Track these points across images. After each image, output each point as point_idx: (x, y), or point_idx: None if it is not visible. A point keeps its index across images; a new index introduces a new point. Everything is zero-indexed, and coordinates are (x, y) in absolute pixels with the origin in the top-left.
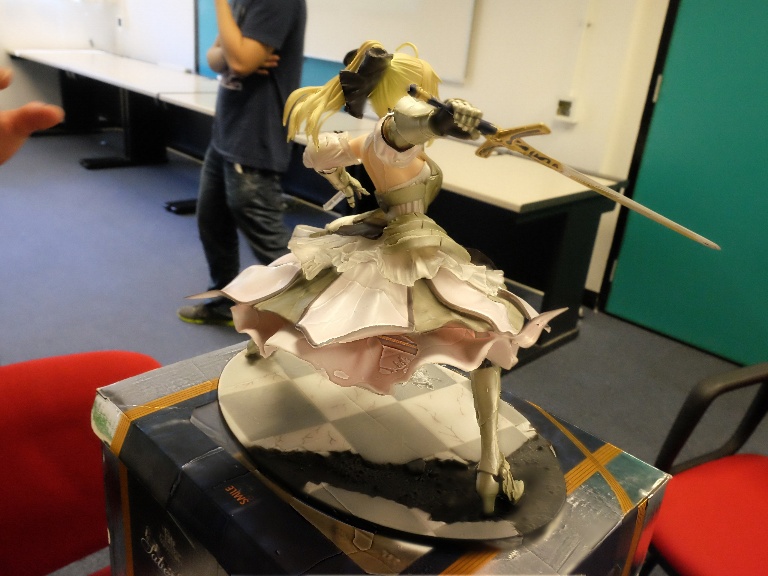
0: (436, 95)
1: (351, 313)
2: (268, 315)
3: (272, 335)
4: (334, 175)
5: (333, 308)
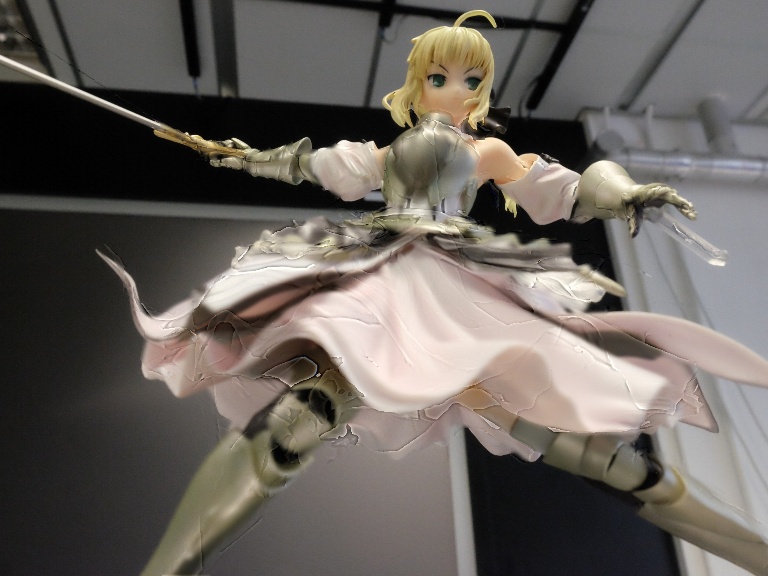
0: (411, 59)
1: (292, 370)
2: (391, 418)
3: (396, 444)
4: (602, 209)
5: (317, 375)
